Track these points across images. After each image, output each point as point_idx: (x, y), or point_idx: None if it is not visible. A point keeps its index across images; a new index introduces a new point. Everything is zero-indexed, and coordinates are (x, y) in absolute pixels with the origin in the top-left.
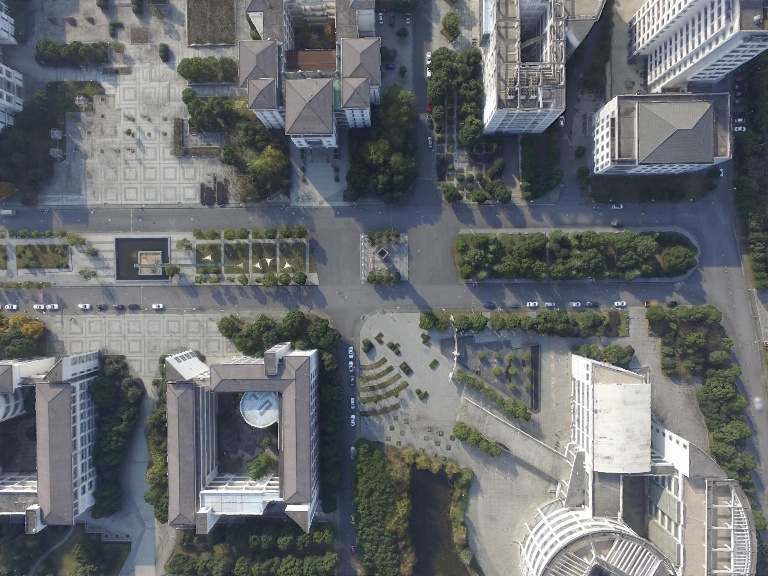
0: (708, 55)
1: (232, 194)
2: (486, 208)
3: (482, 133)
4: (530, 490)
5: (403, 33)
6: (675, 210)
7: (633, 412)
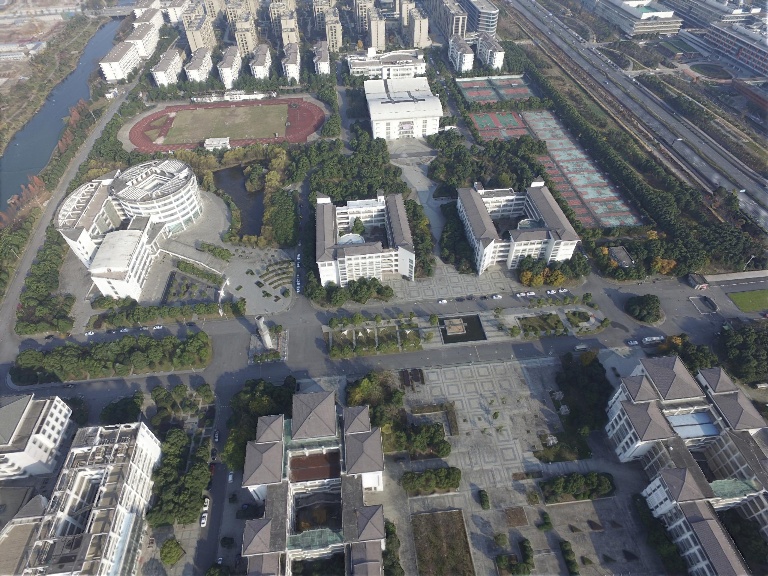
0: None
1: (396, 379)
2: None
3: None
4: (188, 237)
5: (226, 539)
6: None
7: (106, 256)
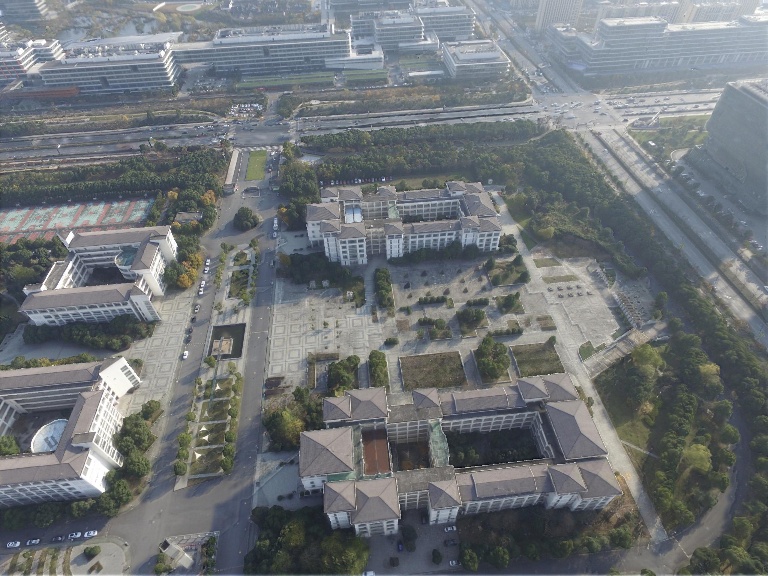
0: None
1: None
2: None
3: None
4: None
5: (435, 556)
6: None
7: None
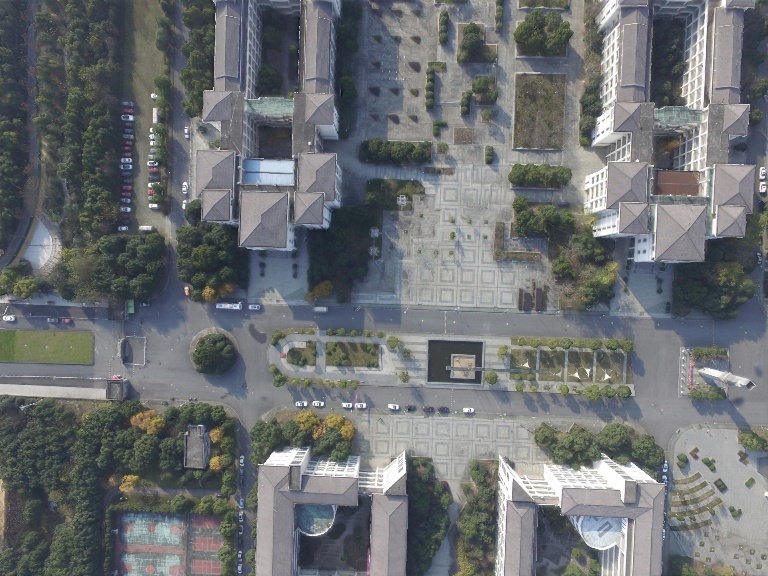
0: None
1: (551, 301)
2: None
3: None
4: None
5: (743, 148)
6: None
7: None
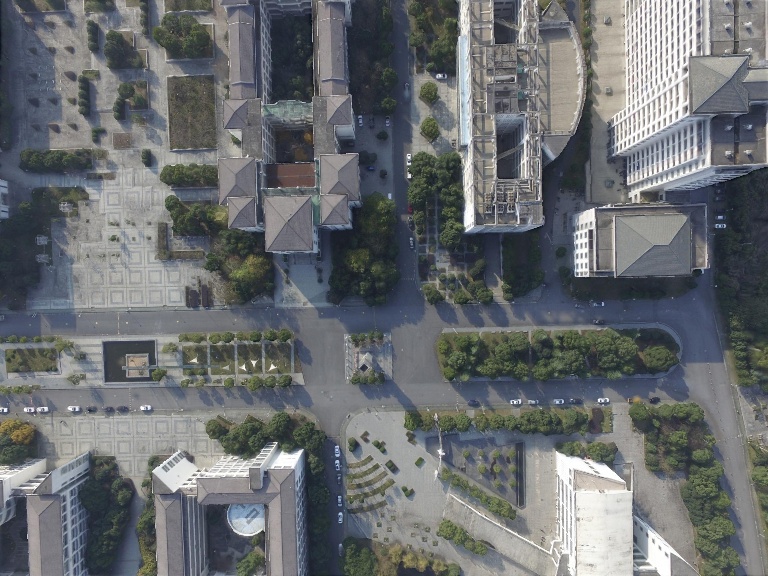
0: (682, 177)
1: (217, 296)
2: (468, 307)
3: (463, 233)
4: None
5: (383, 137)
6: (657, 307)
7: (615, 520)
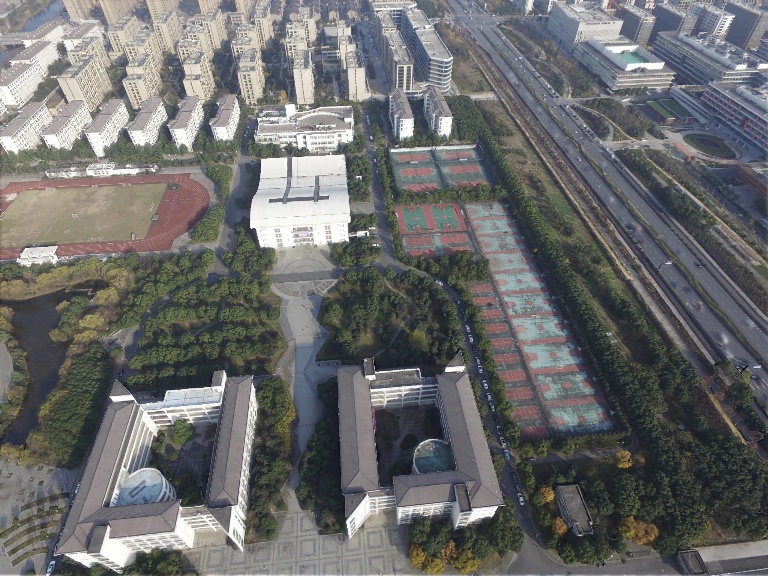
0: None
1: None
2: None
3: None
4: None
5: None
6: None
7: None
